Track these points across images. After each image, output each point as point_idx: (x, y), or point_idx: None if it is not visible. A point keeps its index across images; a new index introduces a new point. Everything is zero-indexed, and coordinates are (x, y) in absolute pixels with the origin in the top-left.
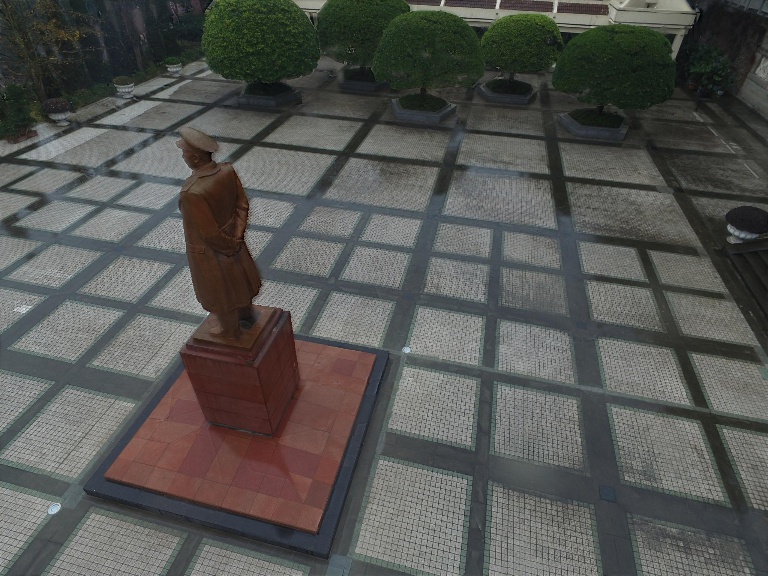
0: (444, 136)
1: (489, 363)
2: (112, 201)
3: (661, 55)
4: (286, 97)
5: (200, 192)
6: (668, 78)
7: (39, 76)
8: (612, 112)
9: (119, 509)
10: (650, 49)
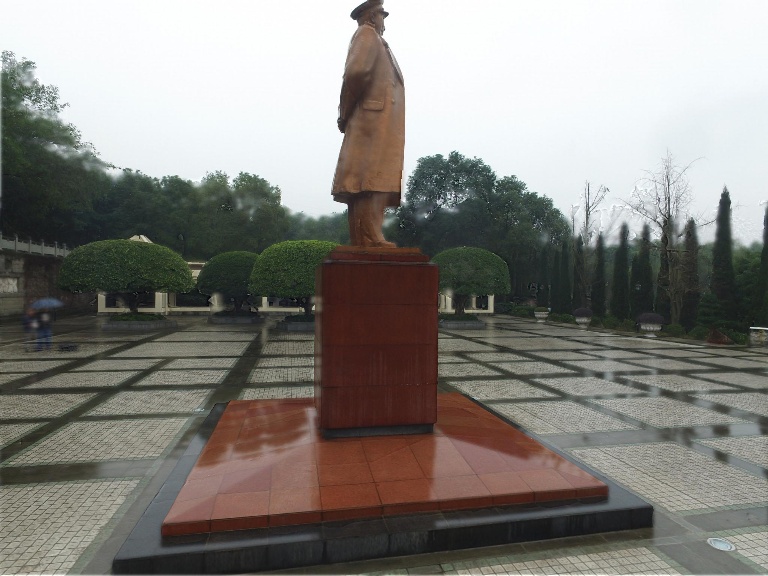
0: None
1: None
2: None
3: None
4: None
5: None
6: None
7: None
8: None
9: None
10: None
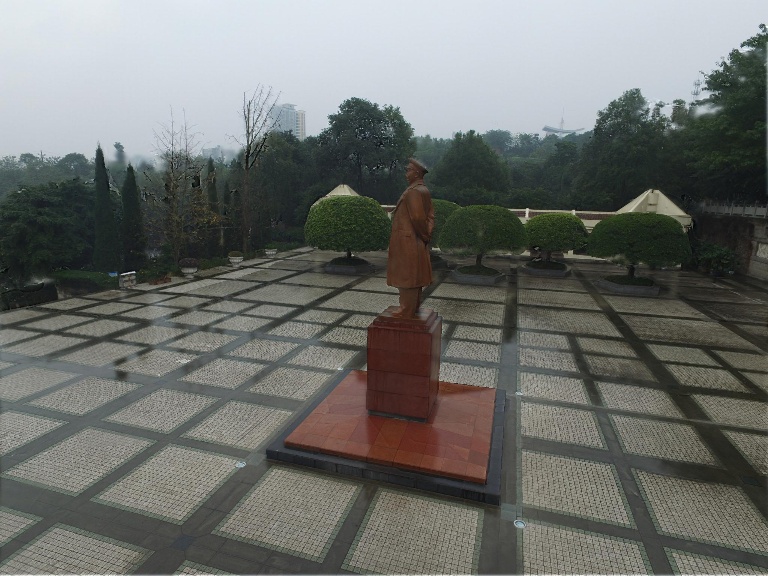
0: (501, 290)
1: (598, 403)
2: (240, 312)
3: (674, 228)
4: (364, 267)
5: (420, 190)
6: (685, 244)
7: (179, 245)
8: (642, 277)
9: (297, 468)
10: (664, 224)
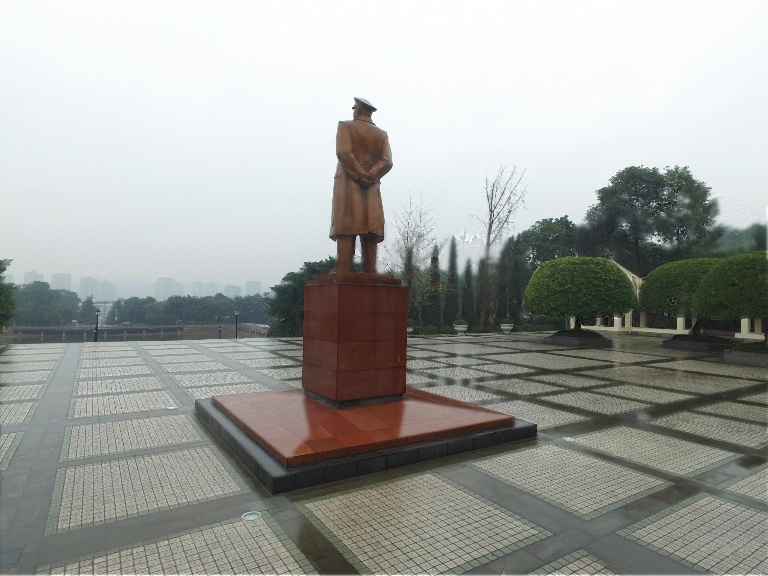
0: None
1: (709, 479)
2: None
3: None
4: (592, 340)
5: (348, 123)
6: None
7: None
8: None
9: (197, 419)
10: None
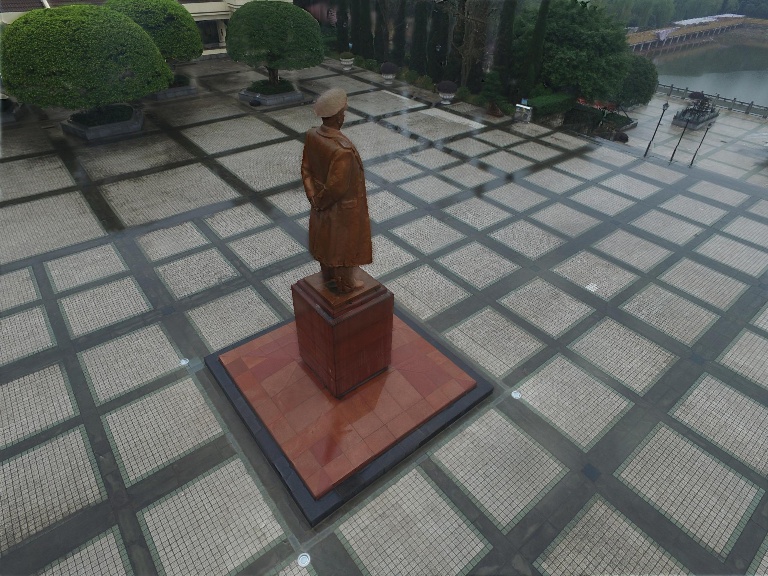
0: None
1: None
2: None
3: None
4: None
5: None
6: None
7: None
8: None
9: None
10: None
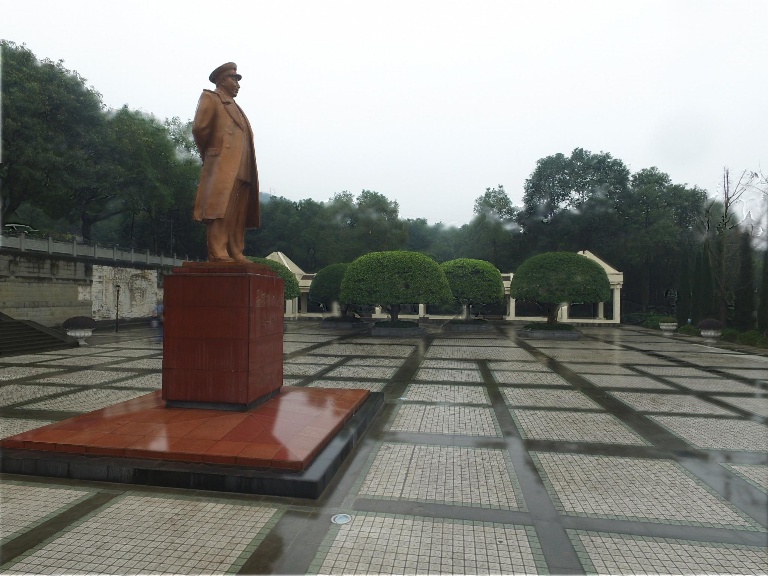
0: None
1: None
2: None
3: None
4: None
5: None
6: None
7: None
8: None
9: None
10: None
